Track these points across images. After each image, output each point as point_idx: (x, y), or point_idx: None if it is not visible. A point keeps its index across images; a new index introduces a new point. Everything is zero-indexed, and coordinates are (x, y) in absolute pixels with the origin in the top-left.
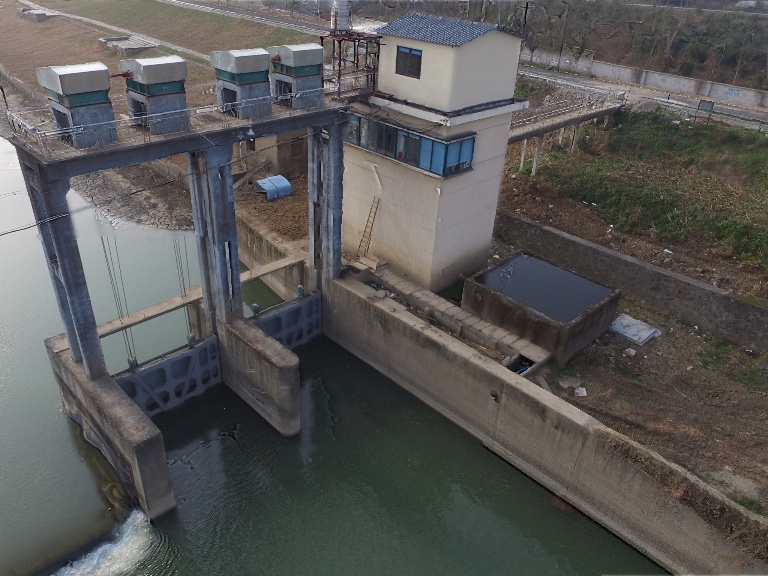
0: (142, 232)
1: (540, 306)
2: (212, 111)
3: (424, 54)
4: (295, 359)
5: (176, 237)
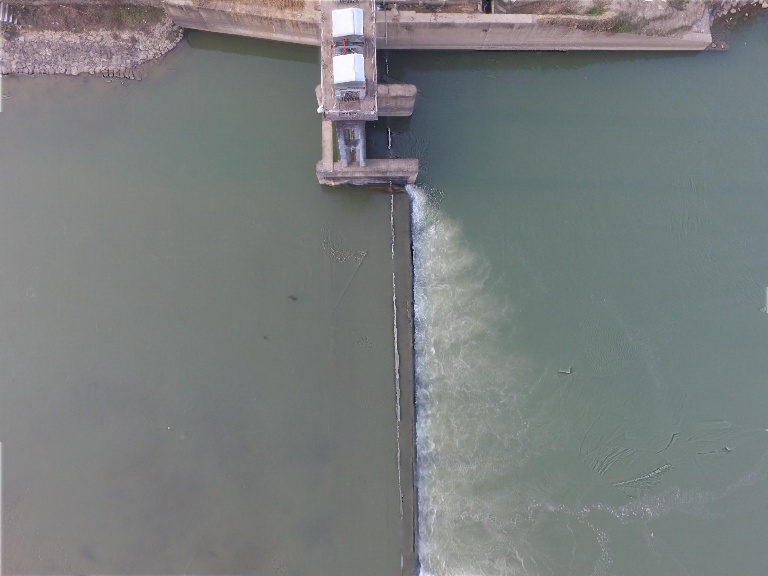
0: (159, 67)
1: None
2: None
3: None
4: (413, 87)
5: (183, 52)
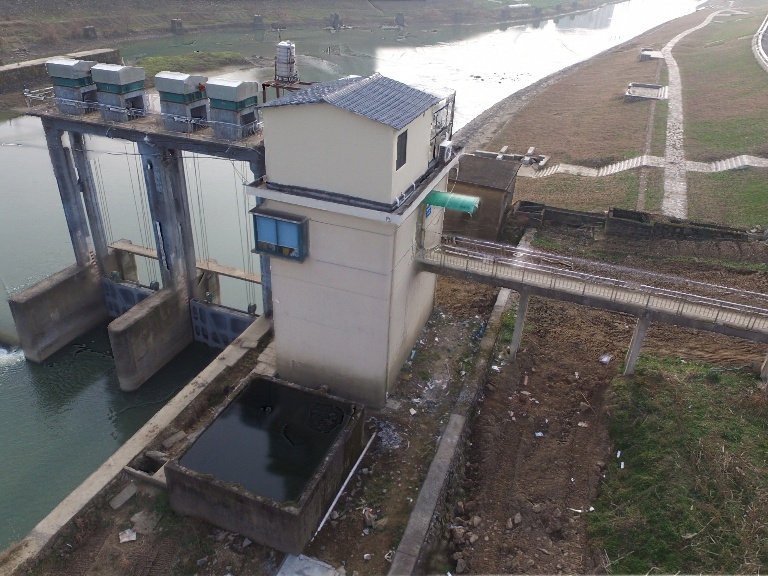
0: None
1: (263, 454)
2: (121, 112)
3: None
4: (120, 328)
5: None
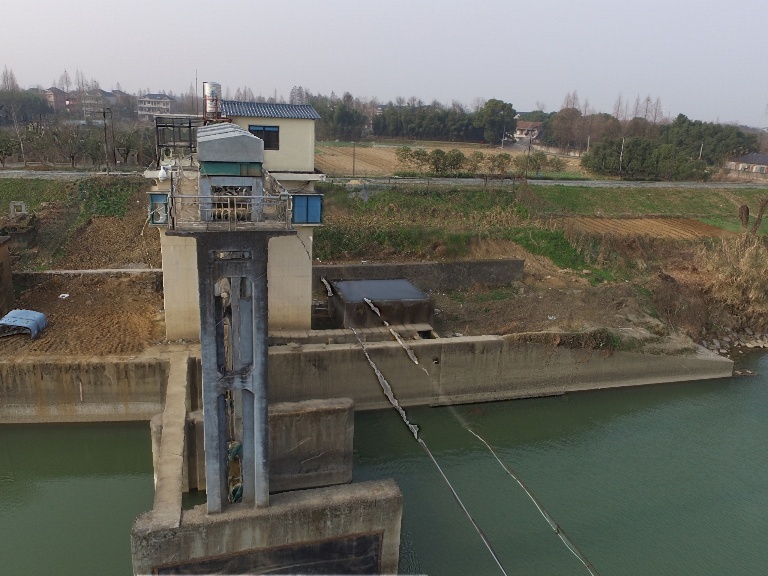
0: None
1: None
2: None
3: (282, 129)
4: (347, 399)
5: None
